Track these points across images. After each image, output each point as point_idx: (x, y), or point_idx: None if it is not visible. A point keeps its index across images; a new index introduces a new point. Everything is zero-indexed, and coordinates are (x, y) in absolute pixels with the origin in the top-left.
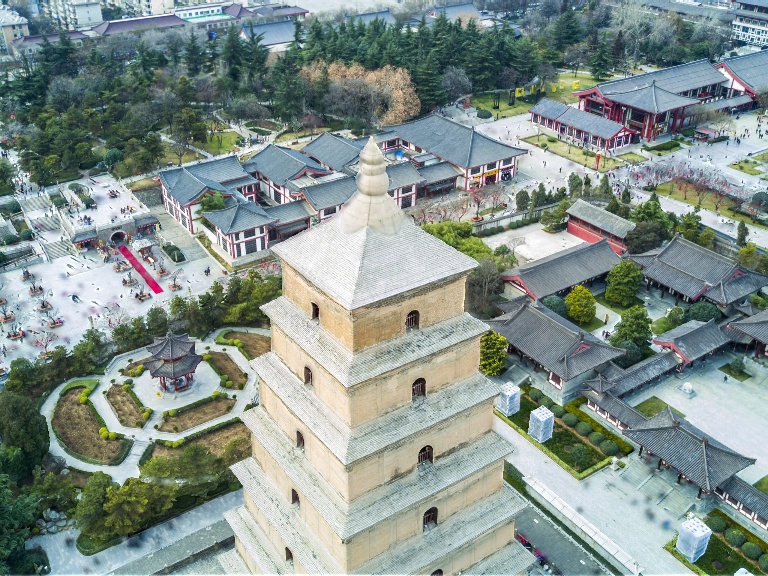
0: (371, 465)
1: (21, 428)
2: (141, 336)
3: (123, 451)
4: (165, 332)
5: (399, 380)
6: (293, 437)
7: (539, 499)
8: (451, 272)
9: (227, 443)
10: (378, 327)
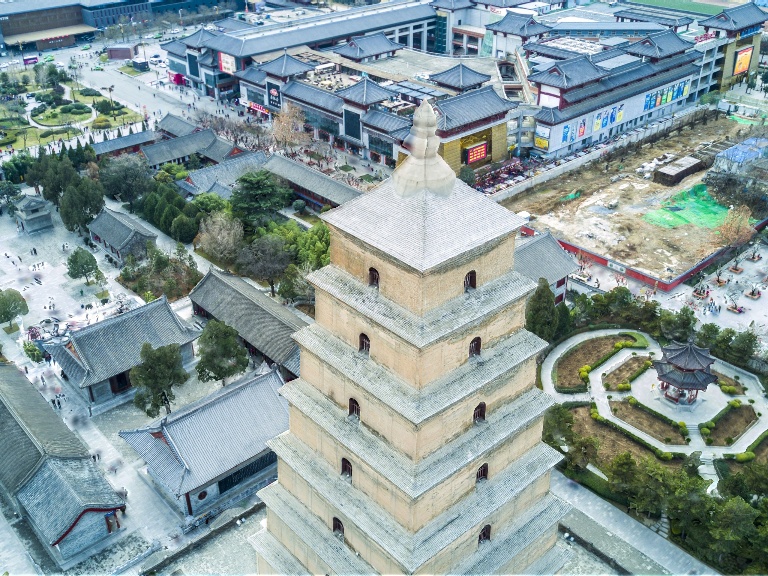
0: (315, 364)
1: (532, 310)
2: (719, 345)
3: (572, 388)
4: (740, 359)
5: (349, 318)
6: None
7: None
8: (397, 254)
9: (622, 453)
10: (348, 257)
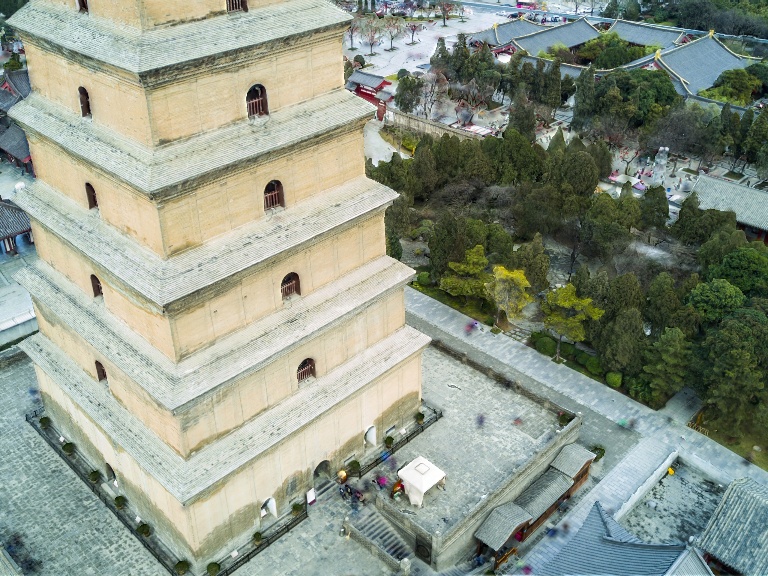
0: None
1: None
2: None
3: None
4: None
5: None
6: (241, 112)
7: (15, 336)
8: None
9: None
10: None
